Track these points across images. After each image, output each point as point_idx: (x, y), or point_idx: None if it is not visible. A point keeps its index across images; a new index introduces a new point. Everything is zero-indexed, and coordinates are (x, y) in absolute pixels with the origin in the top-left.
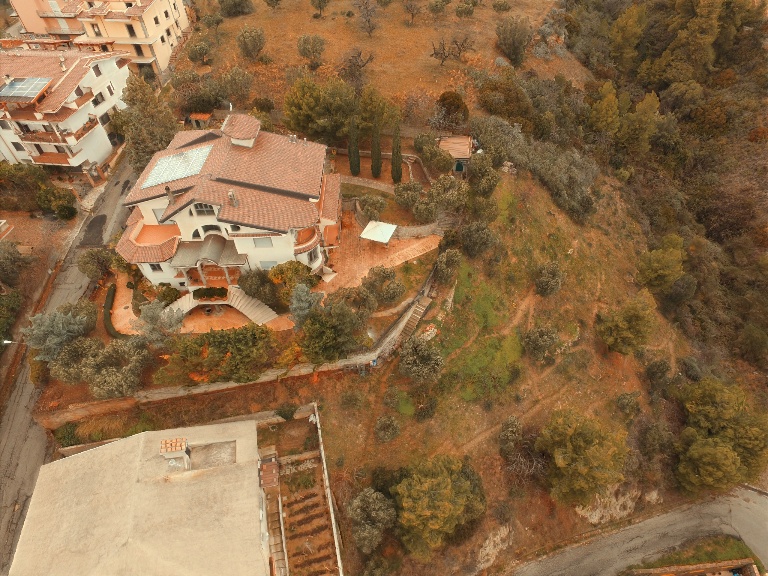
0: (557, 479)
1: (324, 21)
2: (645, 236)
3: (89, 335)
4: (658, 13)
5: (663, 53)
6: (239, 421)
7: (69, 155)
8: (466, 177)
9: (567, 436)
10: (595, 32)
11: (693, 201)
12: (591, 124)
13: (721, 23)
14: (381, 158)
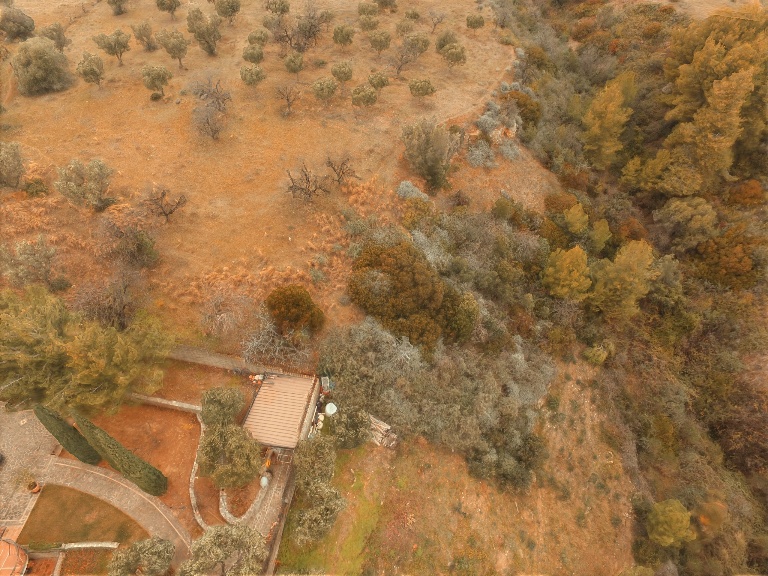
0: None
1: (164, 106)
2: (629, 476)
3: None
4: (652, 77)
5: (658, 153)
6: None
7: None
8: (282, 495)
9: None
10: (564, 112)
11: (703, 401)
12: (547, 284)
13: (744, 120)
14: (162, 408)
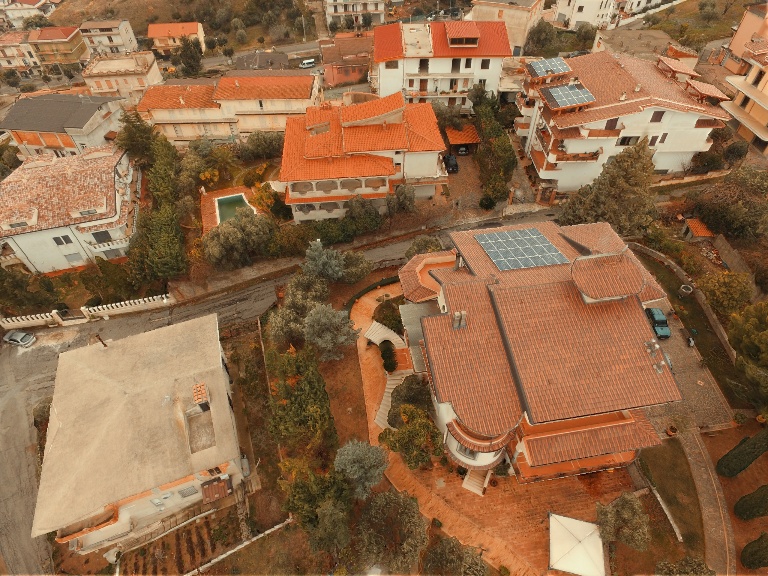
0: None
1: None
2: None
3: (353, 284)
4: None
5: None
6: None
7: (544, 166)
8: None
9: None
10: None
11: None
12: None
13: None
14: None
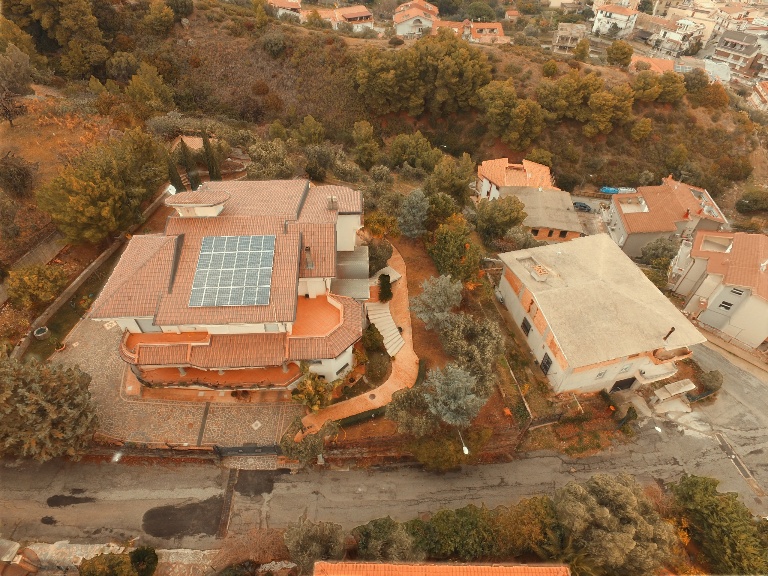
0: (464, 195)
1: None
2: None
3: None
4: None
5: (70, 45)
6: (502, 259)
7: None
8: (239, 148)
9: (450, 175)
10: None
11: None
12: None
13: None
14: (163, 202)
